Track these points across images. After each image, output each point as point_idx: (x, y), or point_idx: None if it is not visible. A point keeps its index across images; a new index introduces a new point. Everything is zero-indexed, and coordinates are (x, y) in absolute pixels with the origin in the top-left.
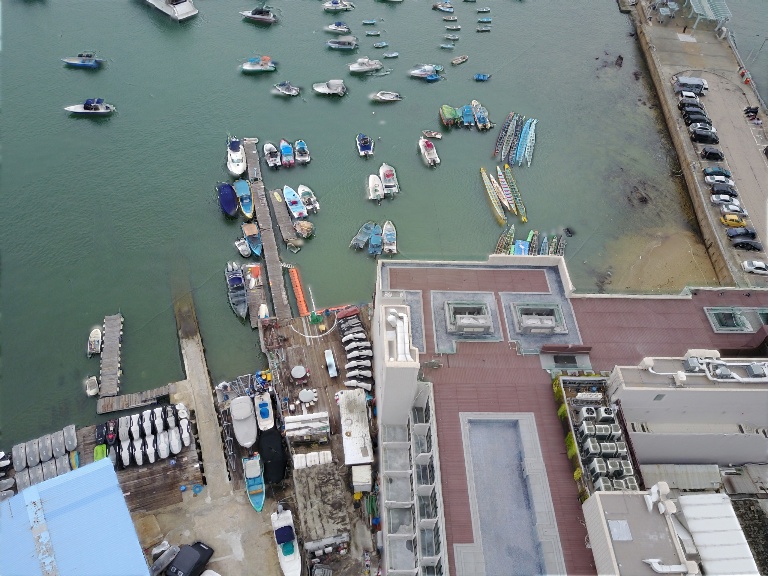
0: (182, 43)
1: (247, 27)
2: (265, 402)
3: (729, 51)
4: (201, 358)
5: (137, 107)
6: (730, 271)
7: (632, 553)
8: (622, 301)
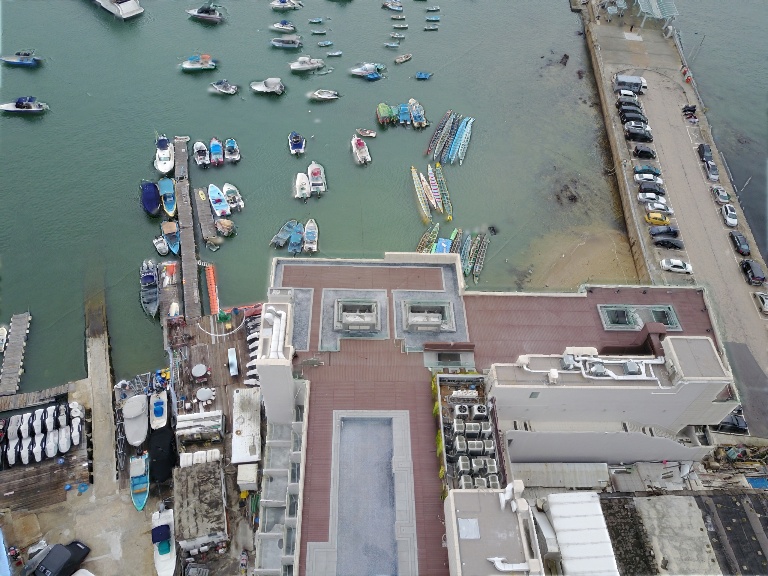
0: (127, 42)
1: (193, 26)
2: (161, 401)
3: (674, 50)
4: (105, 357)
5: (72, 105)
6: (648, 269)
7: (478, 551)
8: (516, 299)
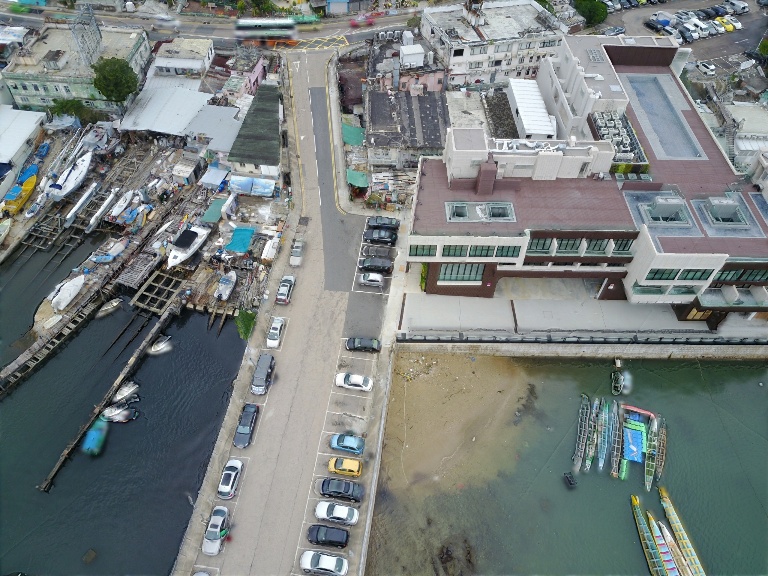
0: None
1: None
2: None
3: None
4: None
5: None
6: None
7: None
8: (590, 229)
